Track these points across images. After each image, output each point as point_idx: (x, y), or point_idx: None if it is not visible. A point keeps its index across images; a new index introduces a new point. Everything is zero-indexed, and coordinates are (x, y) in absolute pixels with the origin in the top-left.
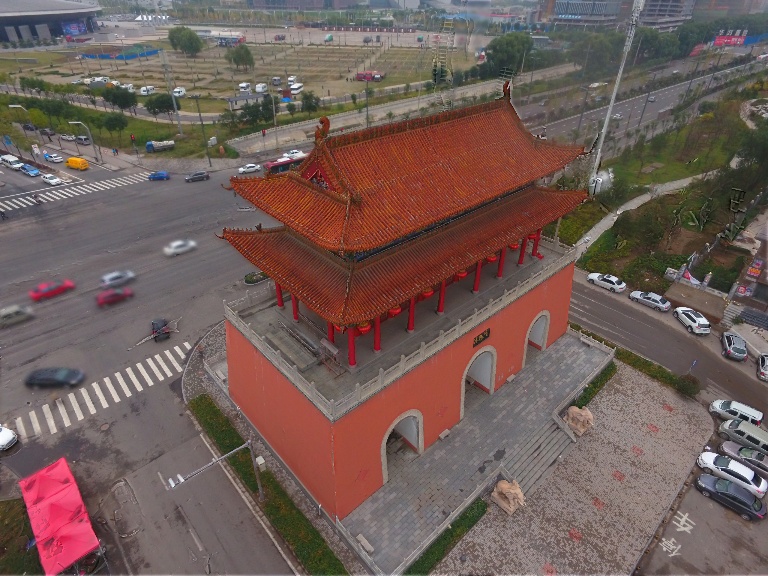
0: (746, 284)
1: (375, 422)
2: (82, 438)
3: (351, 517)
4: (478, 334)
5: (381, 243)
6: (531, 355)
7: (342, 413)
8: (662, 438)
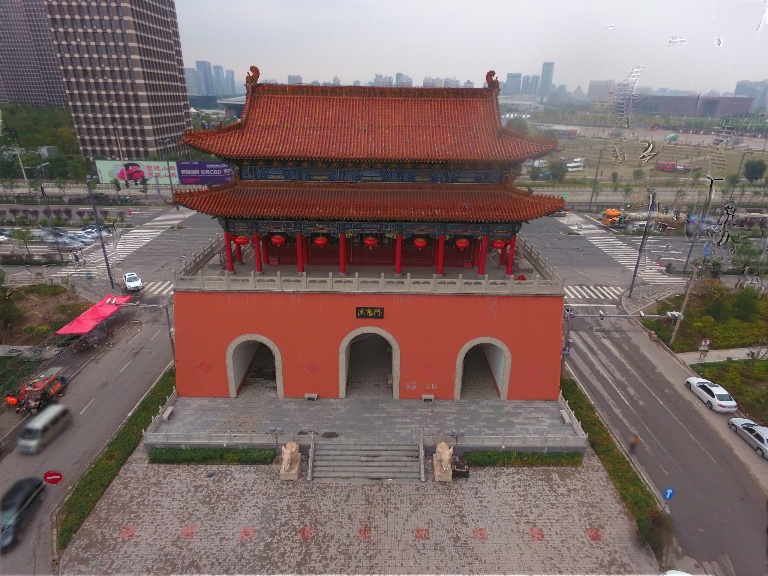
0: None
1: (221, 322)
2: (159, 301)
3: (187, 399)
4: (364, 306)
5: (233, 155)
6: (483, 396)
7: (183, 288)
8: (533, 548)
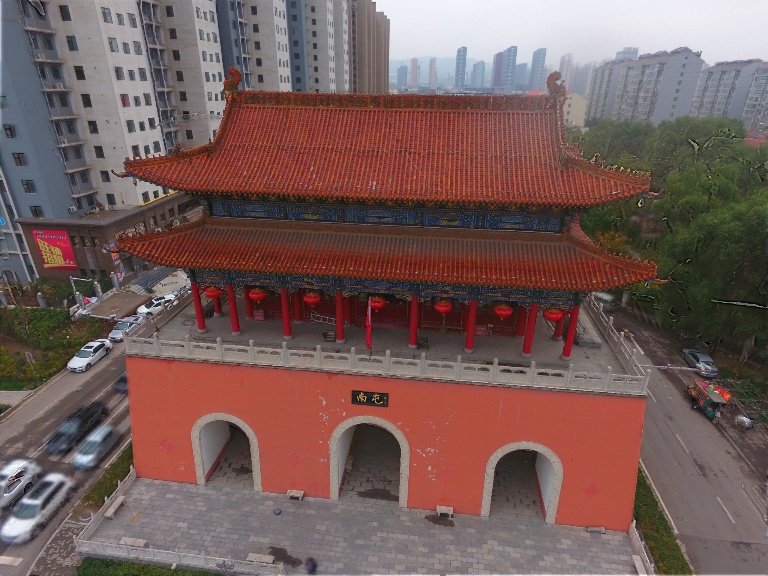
0: (118, 268)
1: None
2: None
3: None
4: None
5: None
6: None
7: None
8: None
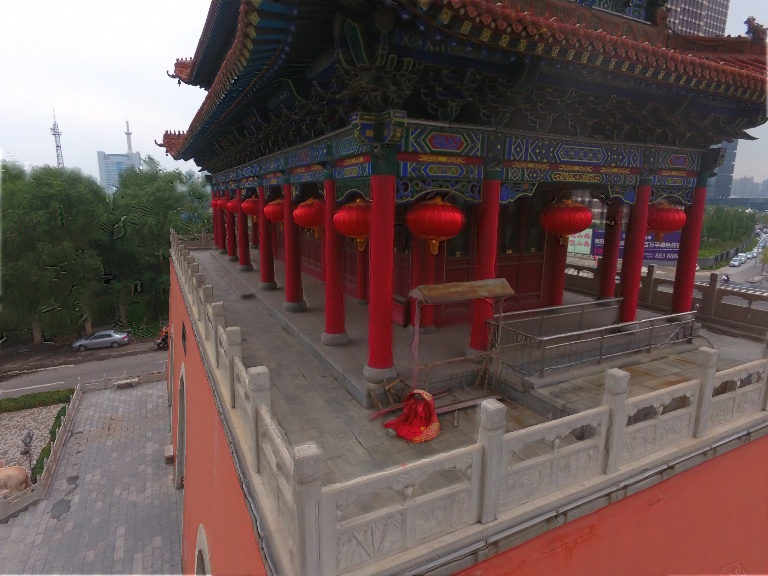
0: None
1: None
2: None
3: (163, 384)
4: None
5: None
6: None
7: None
8: None
